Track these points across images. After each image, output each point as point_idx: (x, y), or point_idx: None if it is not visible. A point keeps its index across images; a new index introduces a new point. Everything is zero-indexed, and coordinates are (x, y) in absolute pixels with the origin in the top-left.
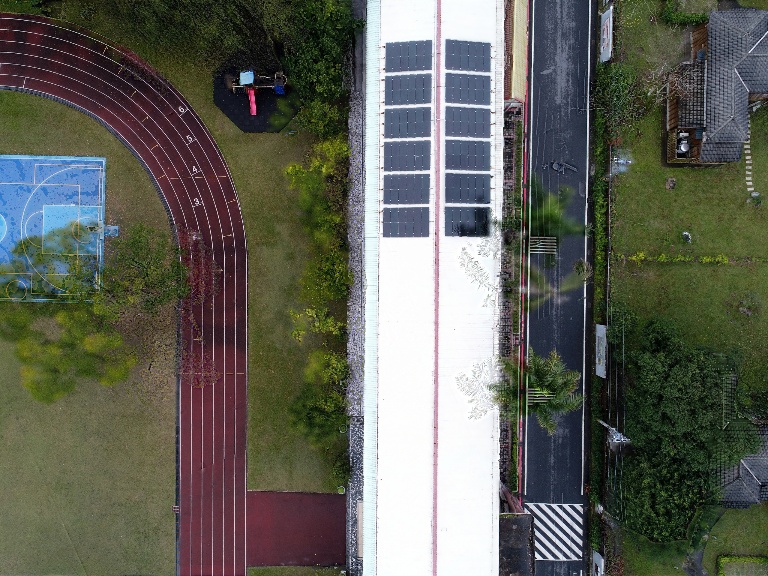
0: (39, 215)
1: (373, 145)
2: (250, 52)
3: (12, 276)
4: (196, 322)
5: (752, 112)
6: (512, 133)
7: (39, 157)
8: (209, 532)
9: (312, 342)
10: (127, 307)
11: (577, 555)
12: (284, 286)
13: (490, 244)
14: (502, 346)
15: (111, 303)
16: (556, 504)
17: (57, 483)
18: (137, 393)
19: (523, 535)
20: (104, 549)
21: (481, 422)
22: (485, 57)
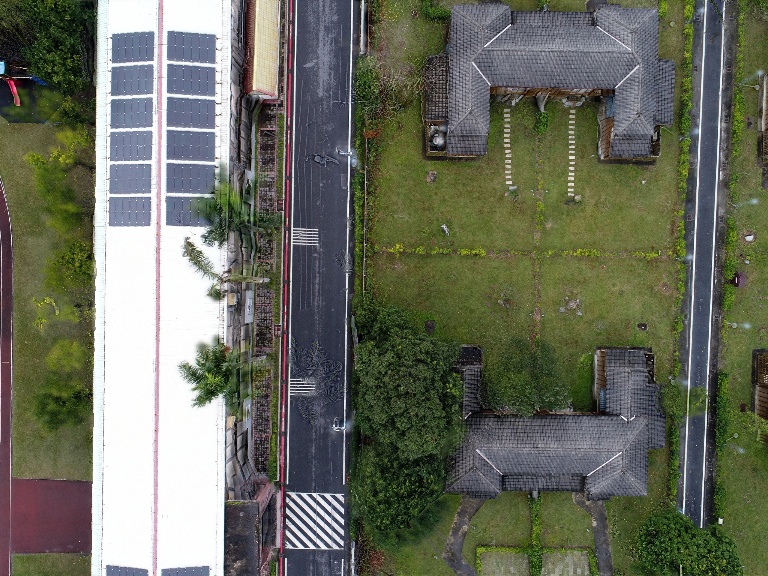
0: None
1: (101, 135)
2: (14, 43)
3: None
4: None
5: (512, 106)
6: (274, 125)
7: None
8: None
9: (76, 331)
10: None
11: (338, 544)
12: (49, 276)
13: (215, 234)
14: (263, 336)
15: None
16: (317, 493)
17: None
18: None
19: (250, 522)
20: None
21: (206, 410)
22: (210, 49)
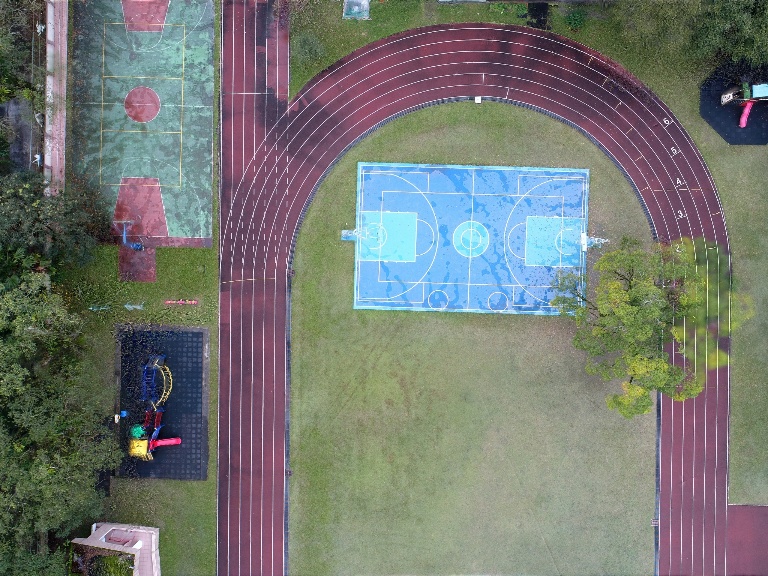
0: (522, 226)
1: None
2: (740, 64)
3: (494, 288)
4: (678, 335)
5: None
6: None
7: (523, 168)
8: (689, 546)
9: None
10: (610, 319)
11: None
12: (767, 299)
13: None
14: None
15: (593, 315)
16: None
17: (537, 496)
18: (618, 406)
19: None
20: (583, 562)
21: None
22: None
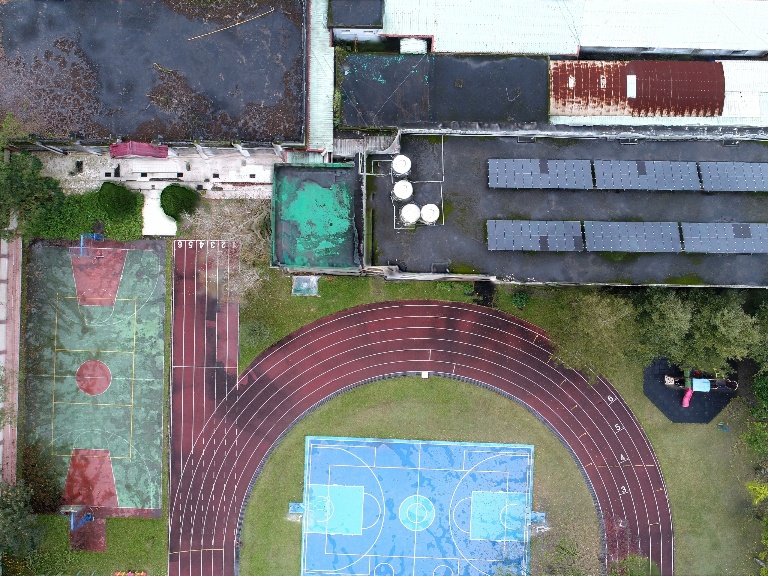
0: (468, 501)
1: None
2: (683, 345)
3: (439, 561)
4: None
5: None
6: None
7: (468, 444)
8: None
9: None
10: None
11: None
12: (710, 575)
13: None
14: None
15: None
16: None
17: None
18: None
19: None
20: None
21: None
22: None
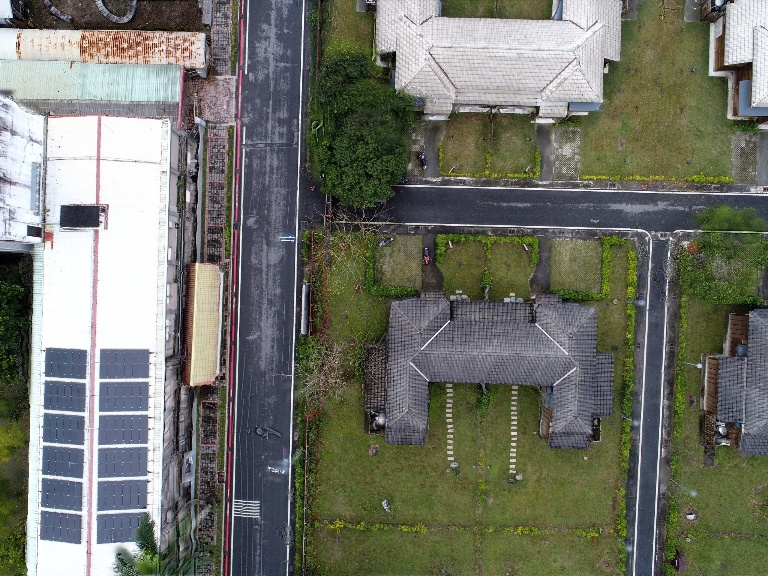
0: None
1: (34, 446)
2: None
3: None
4: None
5: None
6: (216, 398)
7: None
8: None
9: None
10: None
11: None
12: None
13: (146, 548)
14: None
15: None
16: None
17: None
18: None
19: None
20: None
21: None
22: (143, 364)
